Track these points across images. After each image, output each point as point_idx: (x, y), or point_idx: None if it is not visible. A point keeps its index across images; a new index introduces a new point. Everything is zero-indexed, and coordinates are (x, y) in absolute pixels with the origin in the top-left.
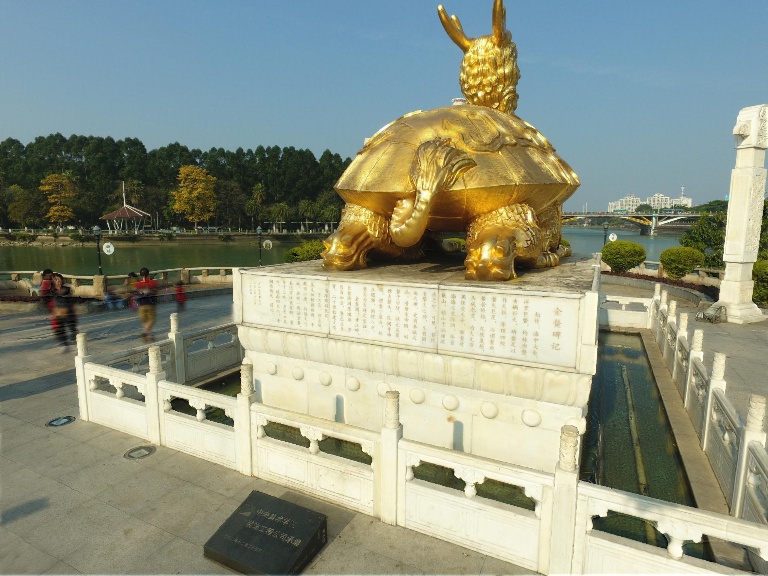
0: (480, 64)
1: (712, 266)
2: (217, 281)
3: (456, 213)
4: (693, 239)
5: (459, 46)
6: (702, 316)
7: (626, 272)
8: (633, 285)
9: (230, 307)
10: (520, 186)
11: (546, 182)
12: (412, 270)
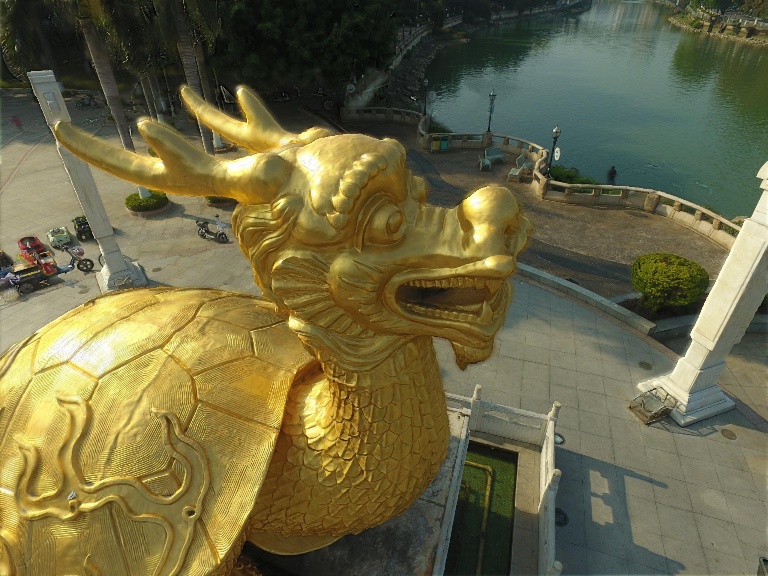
0: None
1: None
2: (687, 222)
3: None
4: None
5: None
6: None
7: None
8: None
9: None
10: None
11: None
12: None
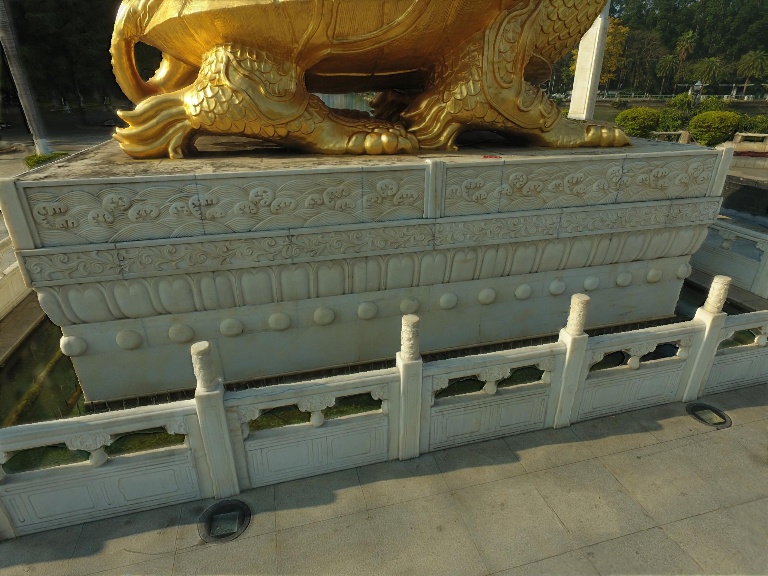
0: None
1: None
2: None
3: (197, 66)
4: None
5: None
6: None
7: None
8: None
9: None
10: (187, 18)
11: (232, 5)
12: (224, 141)
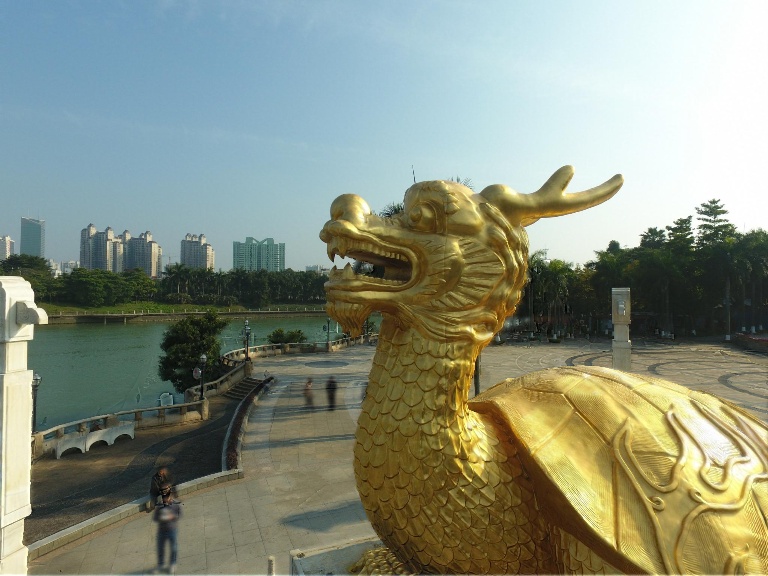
0: None
1: None
2: None
3: None
4: None
5: (542, 213)
6: None
7: None
8: None
9: None
10: None
11: None
12: None
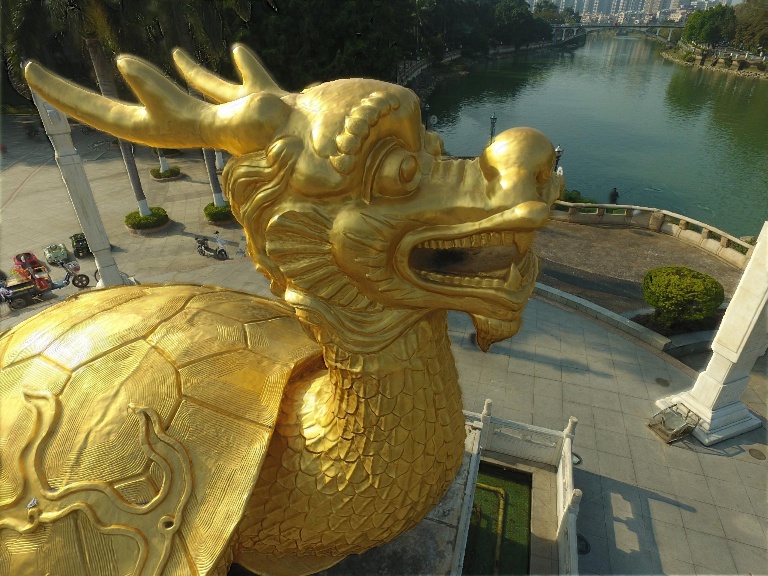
0: None
1: None
2: (693, 241)
3: None
4: None
5: None
6: None
7: None
8: None
9: (448, 315)
10: None
11: None
12: None
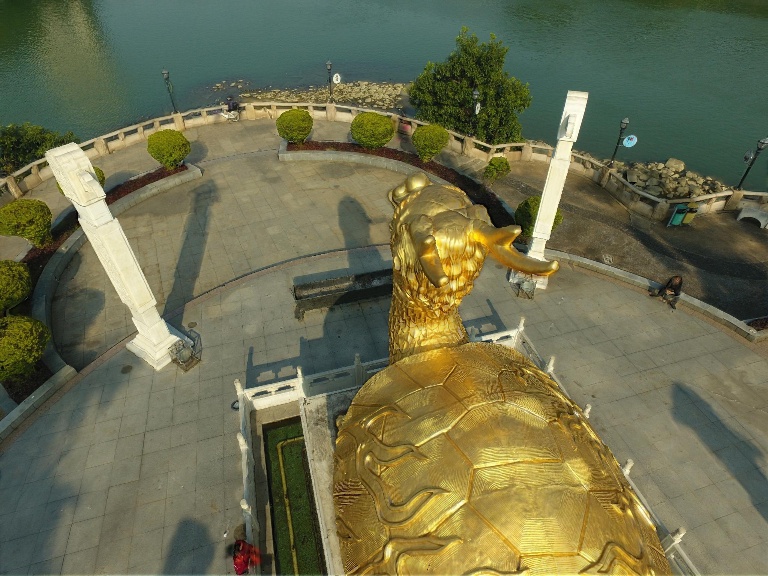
0: (454, 279)
1: (439, 121)
2: None
3: None
4: (421, 91)
5: None
6: (514, 282)
7: (377, 148)
8: (390, 168)
9: None
10: None
11: None
12: None
